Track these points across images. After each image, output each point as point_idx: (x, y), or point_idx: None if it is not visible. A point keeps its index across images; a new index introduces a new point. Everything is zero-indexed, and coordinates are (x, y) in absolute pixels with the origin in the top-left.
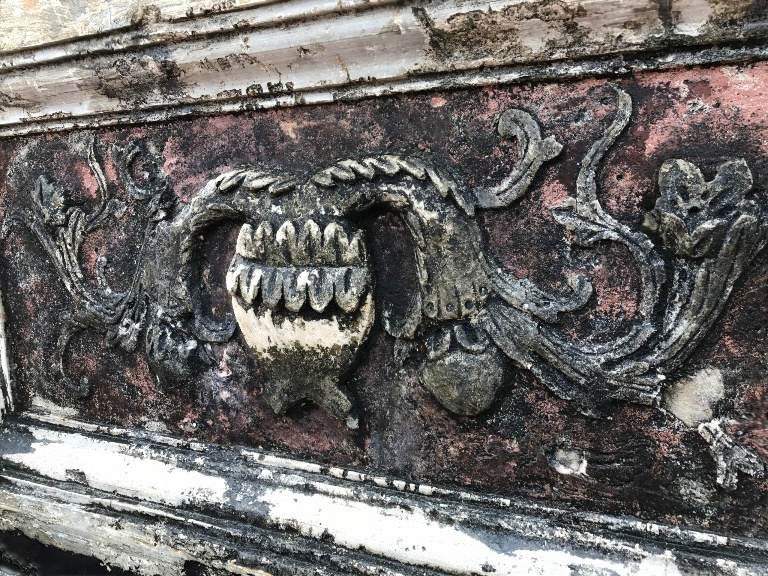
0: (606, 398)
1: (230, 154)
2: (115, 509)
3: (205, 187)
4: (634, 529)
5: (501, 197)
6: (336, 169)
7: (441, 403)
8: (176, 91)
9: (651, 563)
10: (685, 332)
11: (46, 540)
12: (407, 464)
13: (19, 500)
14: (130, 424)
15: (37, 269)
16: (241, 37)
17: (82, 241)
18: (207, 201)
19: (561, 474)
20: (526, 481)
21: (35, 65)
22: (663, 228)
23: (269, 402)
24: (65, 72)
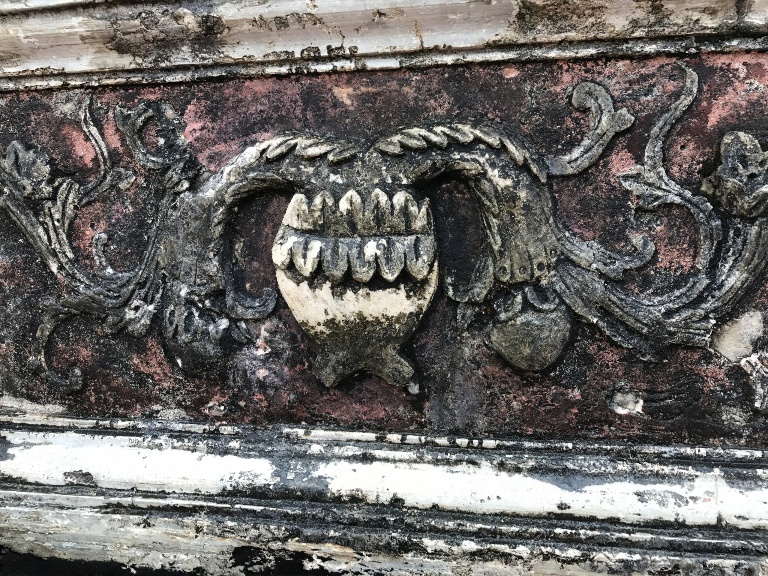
0: (665, 343)
1: (271, 120)
2: (139, 506)
3: (241, 155)
4: (685, 454)
5: (573, 165)
6: (404, 137)
7: (510, 361)
8: (211, 50)
9: (703, 481)
10: (737, 281)
11: (44, 553)
12: (468, 422)
13: (5, 513)
14: (138, 415)
15: (6, 250)
16: None
17: (73, 216)
18: (247, 170)
19: (620, 414)
20: (586, 424)
21: (23, 11)
22: (724, 192)
23: (319, 376)
24: (66, 21)
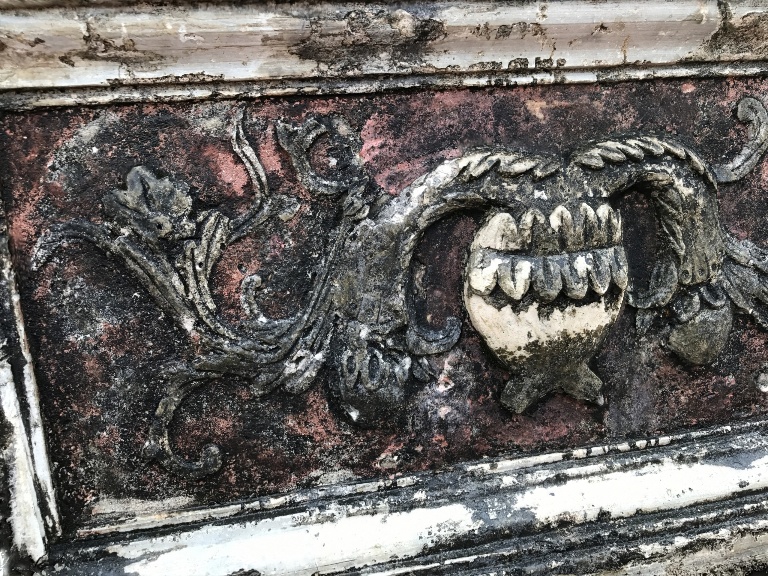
0: None
1: (460, 135)
2: None
3: (431, 174)
4: None
5: (736, 172)
6: (603, 151)
7: (687, 359)
8: (413, 58)
9: None
10: None
11: None
12: (643, 424)
13: None
14: (292, 487)
15: (112, 309)
16: (538, 5)
17: (218, 257)
18: (443, 190)
19: (764, 392)
20: (738, 406)
21: (193, 1)
22: None
23: (511, 403)
24: (251, 17)
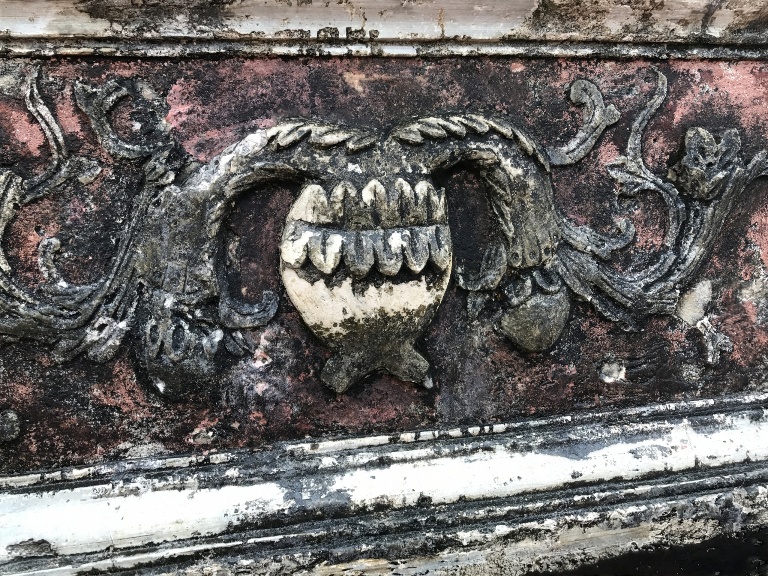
0: (644, 314)
1: (273, 105)
2: (123, 567)
3: (241, 143)
4: (659, 411)
5: (571, 156)
6: (423, 126)
7: (520, 344)
8: (213, 22)
9: (677, 431)
10: (697, 255)
11: None
12: (478, 410)
13: None
14: (99, 458)
15: None
16: None
17: (12, 218)
18: (251, 159)
19: (608, 383)
20: (580, 397)
21: None
22: (689, 179)
23: (331, 382)
24: None
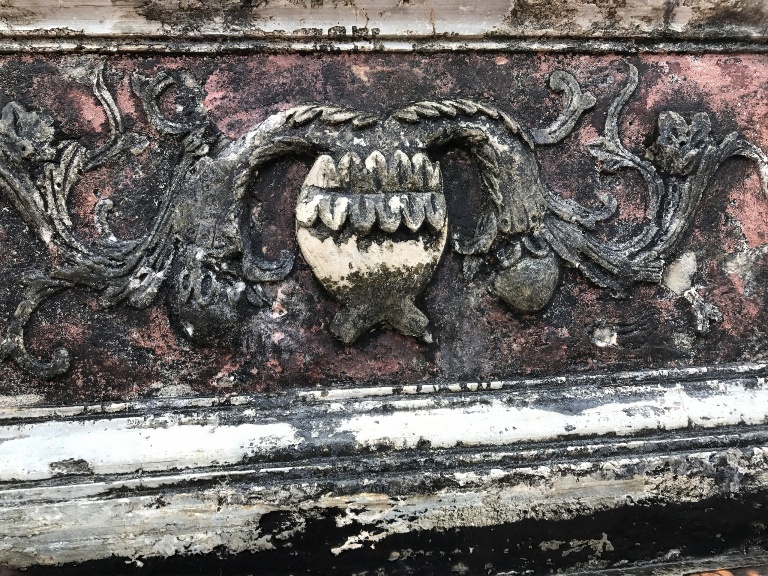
0: (631, 281)
1: (292, 92)
2: (149, 487)
3: (264, 122)
4: (652, 376)
5: (553, 136)
6: (419, 108)
7: (512, 304)
8: (243, 22)
9: (670, 395)
10: (678, 227)
11: (23, 561)
12: (476, 367)
13: None
14: (134, 396)
15: None
16: None
17: (75, 181)
18: (272, 134)
19: (600, 347)
20: (574, 359)
21: None
22: (664, 156)
23: (339, 332)
24: None
